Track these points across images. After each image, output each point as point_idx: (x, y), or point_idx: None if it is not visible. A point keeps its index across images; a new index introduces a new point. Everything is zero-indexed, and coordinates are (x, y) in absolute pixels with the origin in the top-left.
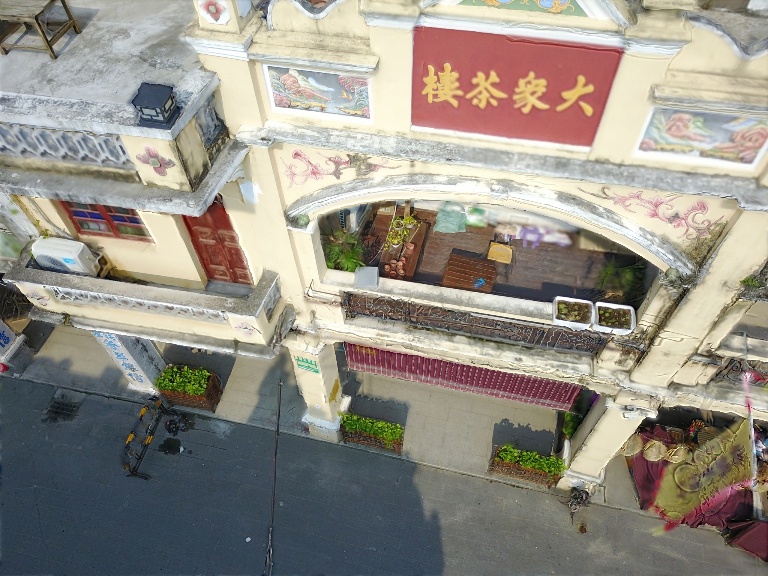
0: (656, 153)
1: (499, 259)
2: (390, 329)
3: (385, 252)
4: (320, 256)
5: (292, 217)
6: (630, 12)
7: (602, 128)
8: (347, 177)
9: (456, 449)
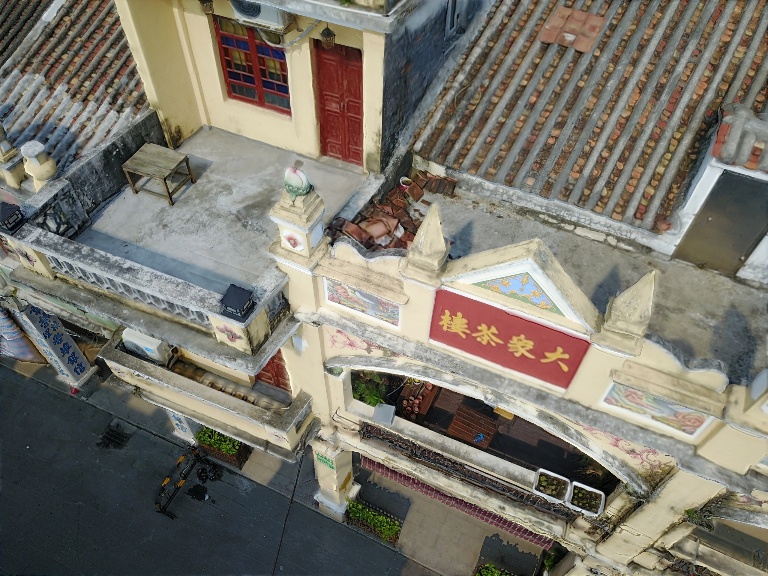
0: (617, 407)
1: (503, 414)
2: (398, 455)
3: (407, 387)
4: (348, 392)
5: (329, 368)
6: (597, 323)
7: (574, 382)
8: (376, 354)
9: (446, 553)
